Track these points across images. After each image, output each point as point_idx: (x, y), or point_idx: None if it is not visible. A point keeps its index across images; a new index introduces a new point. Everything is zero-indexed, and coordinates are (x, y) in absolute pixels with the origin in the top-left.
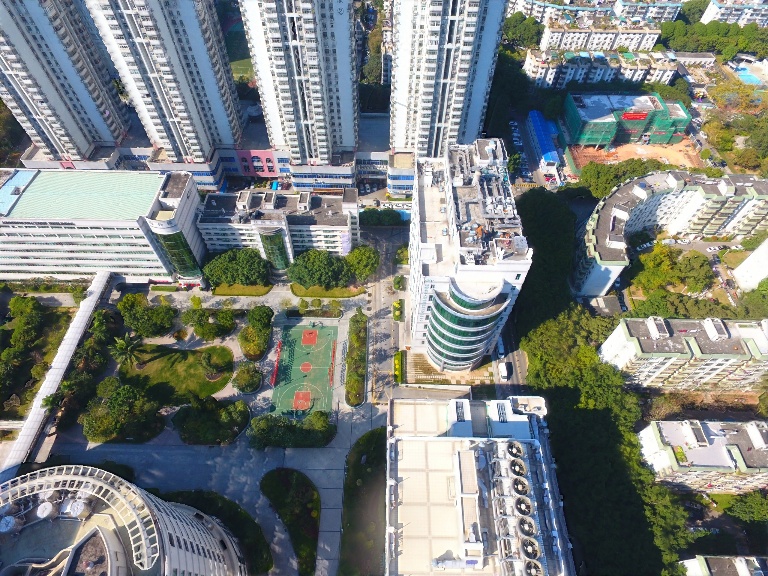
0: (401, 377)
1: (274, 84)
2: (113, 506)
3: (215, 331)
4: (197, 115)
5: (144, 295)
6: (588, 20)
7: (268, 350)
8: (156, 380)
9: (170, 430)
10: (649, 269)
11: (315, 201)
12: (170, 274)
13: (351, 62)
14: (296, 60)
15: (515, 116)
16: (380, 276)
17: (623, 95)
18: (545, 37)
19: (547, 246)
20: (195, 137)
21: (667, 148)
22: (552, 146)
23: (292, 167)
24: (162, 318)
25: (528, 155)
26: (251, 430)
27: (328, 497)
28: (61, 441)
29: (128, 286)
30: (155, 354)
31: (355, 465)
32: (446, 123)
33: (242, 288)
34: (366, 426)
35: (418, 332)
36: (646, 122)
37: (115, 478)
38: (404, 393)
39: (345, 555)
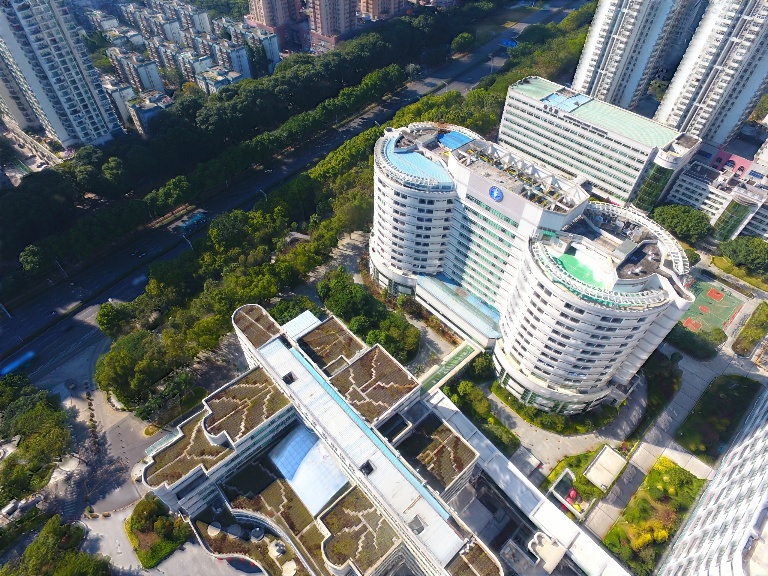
0: None
1: None
2: (664, 241)
3: None
4: (717, 109)
5: None
6: None
7: None
8: None
9: None
10: None
11: None
12: (627, 201)
13: None
14: None
15: None
16: None
17: None
18: None
19: None
20: (704, 124)
21: None
22: None
23: (767, 179)
24: None
25: None
26: None
27: (688, 389)
28: None
29: None
30: None
31: (722, 386)
32: None
33: None
34: (742, 372)
35: None
36: None
37: (666, 232)
38: None
39: (689, 426)
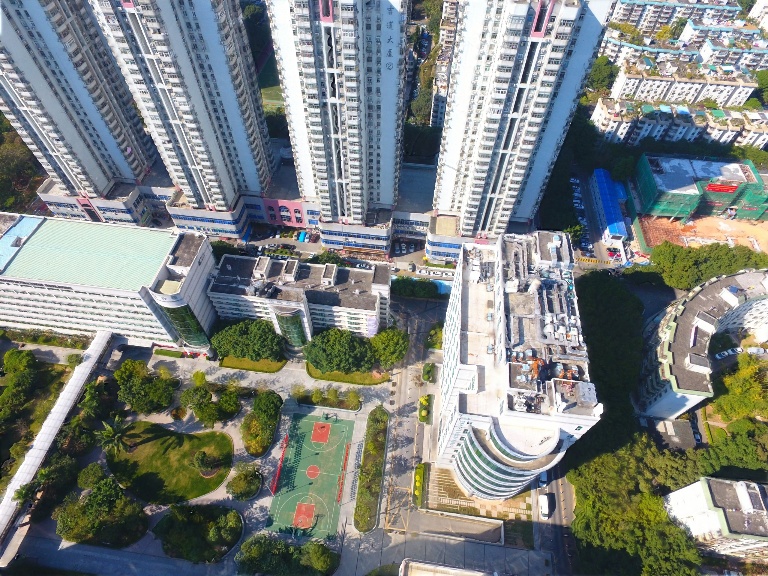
0: (421, 499)
1: (308, 136)
2: None
3: (215, 418)
4: (222, 162)
5: (144, 363)
6: (671, 67)
7: (273, 444)
8: (145, 469)
9: (152, 536)
10: (734, 395)
11: (342, 274)
12: (175, 340)
13: (397, 120)
14: (334, 117)
15: (577, 171)
16: (408, 361)
17: (709, 161)
18: (619, 81)
19: (609, 352)
20: (218, 186)
21: (756, 225)
22: (619, 215)
23: (321, 224)
24: (159, 396)
25: (590, 222)
26: (241, 555)
27: None
28: (33, 534)
29: (131, 346)
30: (148, 435)
31: None
32: (500, 194)
33: (253, 361)
34: (375, 560)
35: (446, 454)
36: (734, 195)
37: None
38: (423, 520)
39: None
